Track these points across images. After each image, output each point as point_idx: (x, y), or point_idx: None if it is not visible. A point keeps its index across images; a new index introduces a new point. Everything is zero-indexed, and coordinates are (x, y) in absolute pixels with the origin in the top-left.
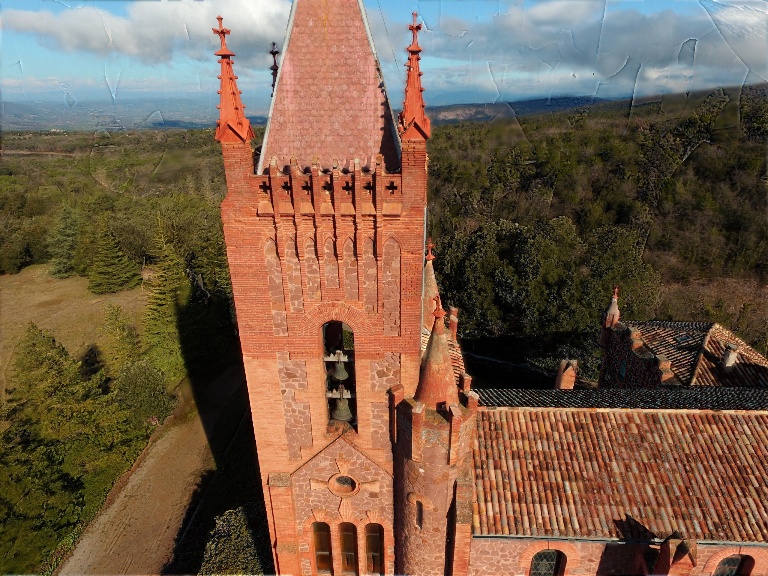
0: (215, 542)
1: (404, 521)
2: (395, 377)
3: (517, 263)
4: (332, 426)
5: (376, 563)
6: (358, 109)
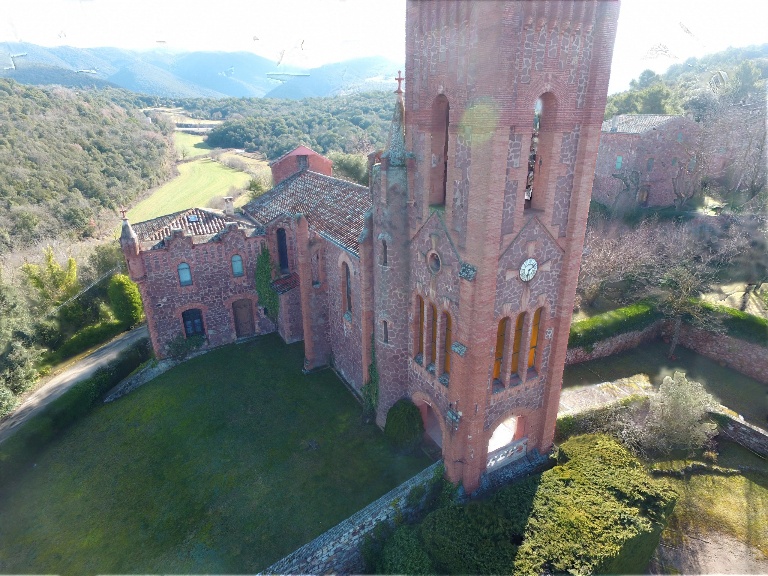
0: None
1: None
2: None
3: None
4: None
5: None
6: None
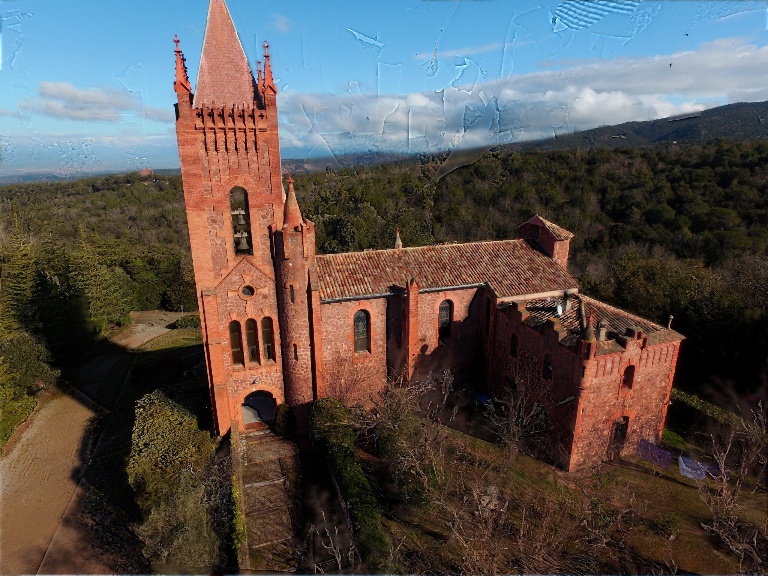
0: None
1: (284, 305)
2: (271, 218)
3: (340, 237)
4: (238, 255)
5: (269, 352)
6: (241, 82)
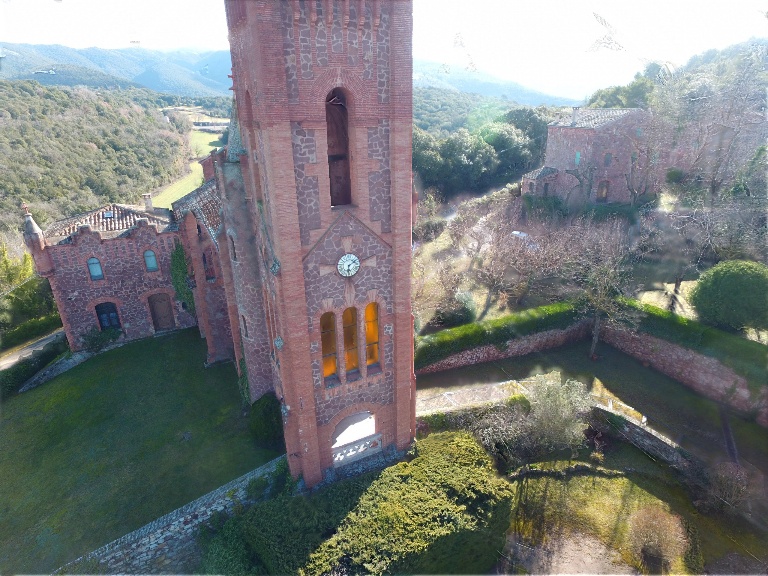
0: (361, 575)
1: None
2: None
3: None
4: None
5: None
6: None
